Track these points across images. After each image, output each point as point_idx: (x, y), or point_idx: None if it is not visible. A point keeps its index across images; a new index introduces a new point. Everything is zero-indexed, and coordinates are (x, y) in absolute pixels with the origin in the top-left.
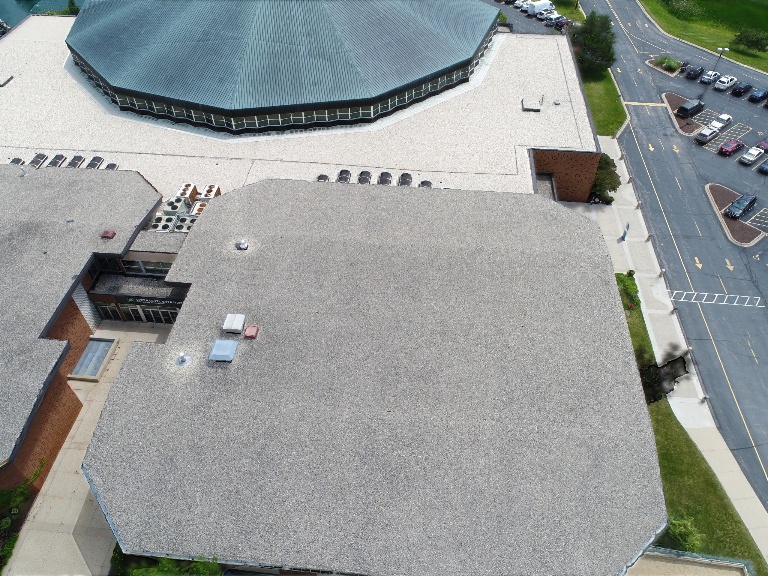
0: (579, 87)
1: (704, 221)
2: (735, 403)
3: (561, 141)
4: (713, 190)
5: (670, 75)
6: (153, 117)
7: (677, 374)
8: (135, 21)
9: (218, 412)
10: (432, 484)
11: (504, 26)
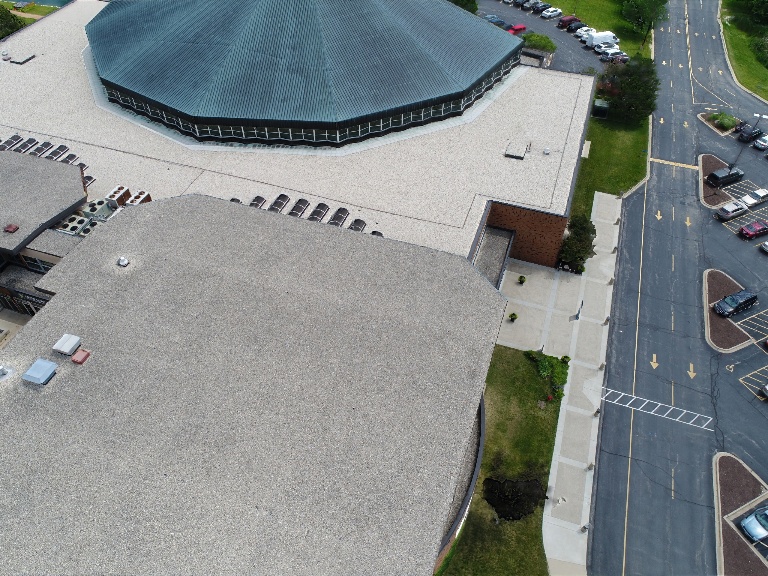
0: (580, 137)
1: (684, 313)
2: (623, 541)
3: (530, 197)
4: (711, 277)
5: (720, 134)
6: (134, 112)
7: (531, 498)
8: (144, 15)
9: (7, 435)
10: (170, 568)
11: (535, 58)
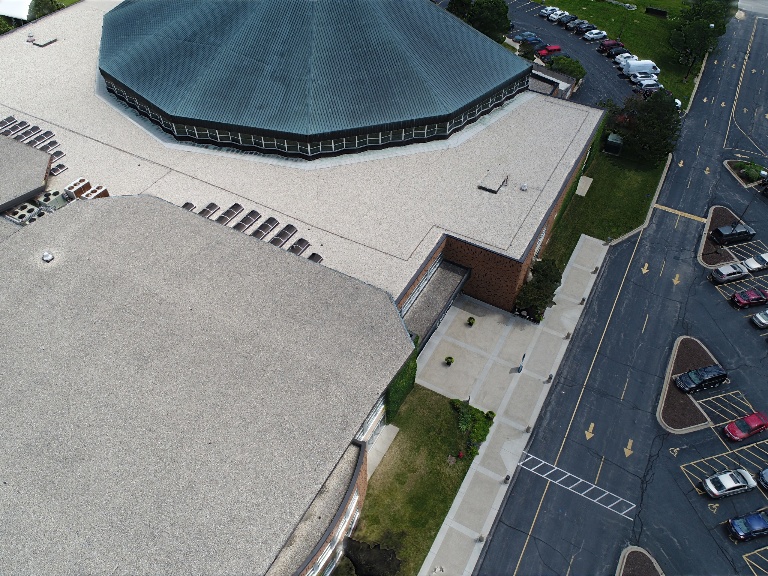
0: (566, 176)
1: (641, 381)
2: None
3: (489, 235)
4: (684, 346)
5: (743, 185)
6: (127, 104)
7: (380, 567)
8: (155, 9)
9: None
10: None
11: (550, 84)
